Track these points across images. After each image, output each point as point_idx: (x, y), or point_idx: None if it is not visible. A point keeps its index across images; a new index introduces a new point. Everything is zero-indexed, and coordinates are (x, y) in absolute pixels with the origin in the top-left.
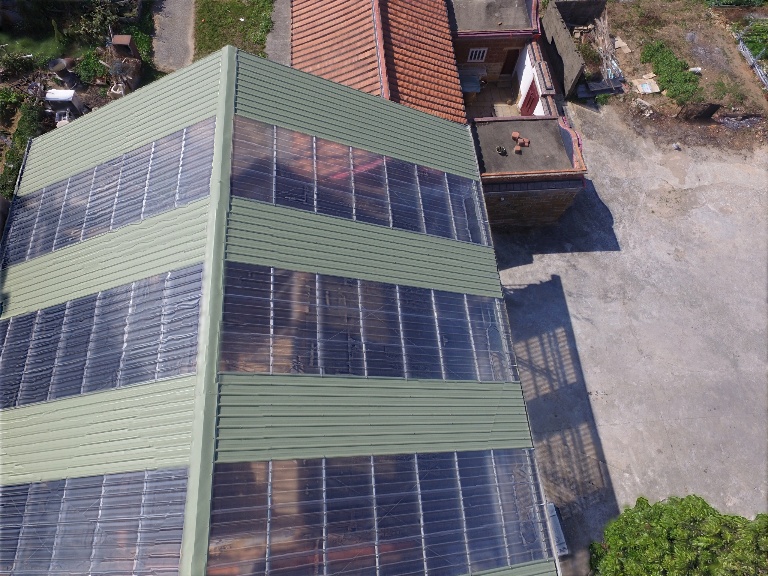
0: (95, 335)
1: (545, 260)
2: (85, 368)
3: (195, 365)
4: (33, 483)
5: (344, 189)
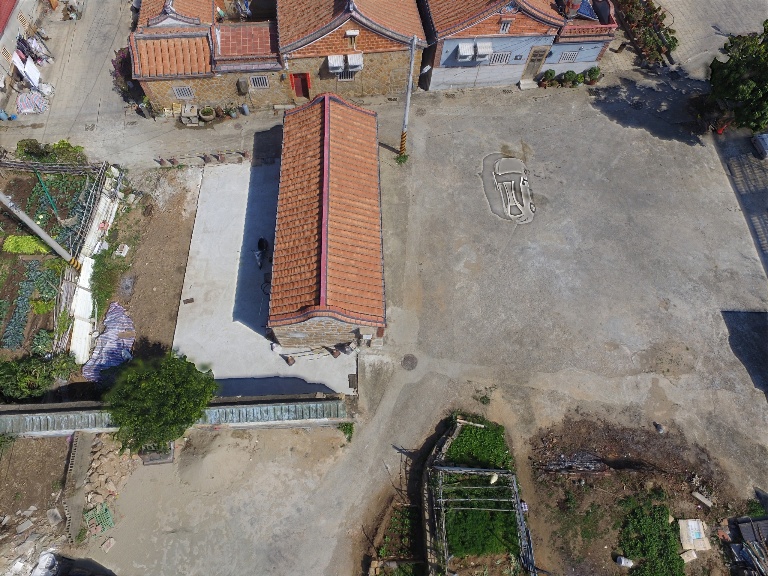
0: None
1: None
2: None
3: None
4: None
5: None
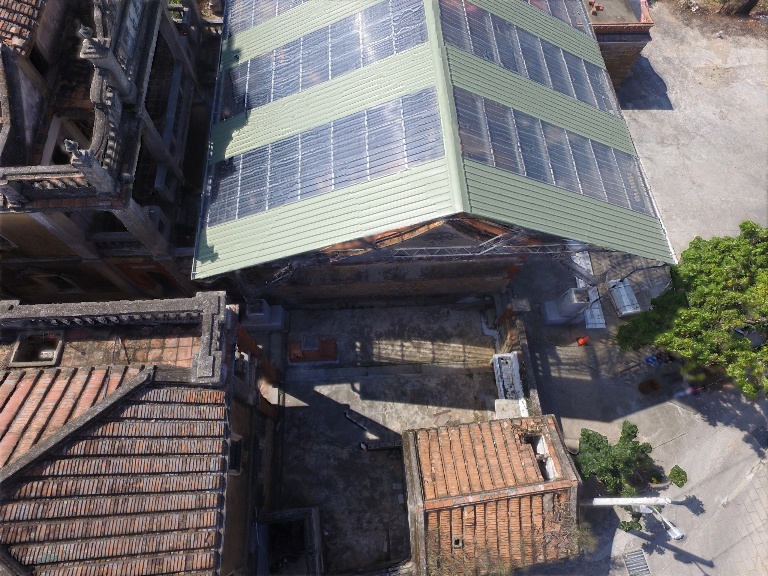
0: (332, 48)
1: None
2: (330, 66)
3: (428, 37)
4: (302, 132)
5: None
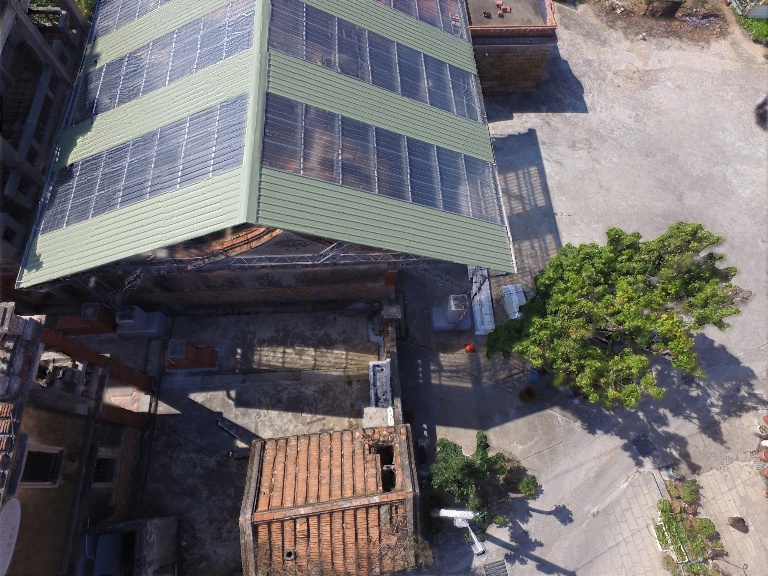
0: (175, 53)
1: (524, 118)
2: (168, 71)
3: (252, 43)
4: (133, 139)
5: None
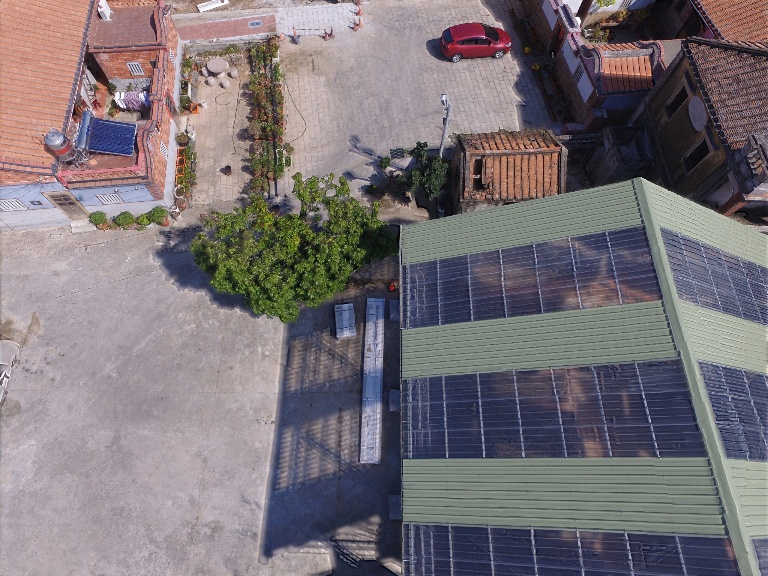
0: None
1: None
2: None
3: None
4: (763, 324)
5: (596, 575)
